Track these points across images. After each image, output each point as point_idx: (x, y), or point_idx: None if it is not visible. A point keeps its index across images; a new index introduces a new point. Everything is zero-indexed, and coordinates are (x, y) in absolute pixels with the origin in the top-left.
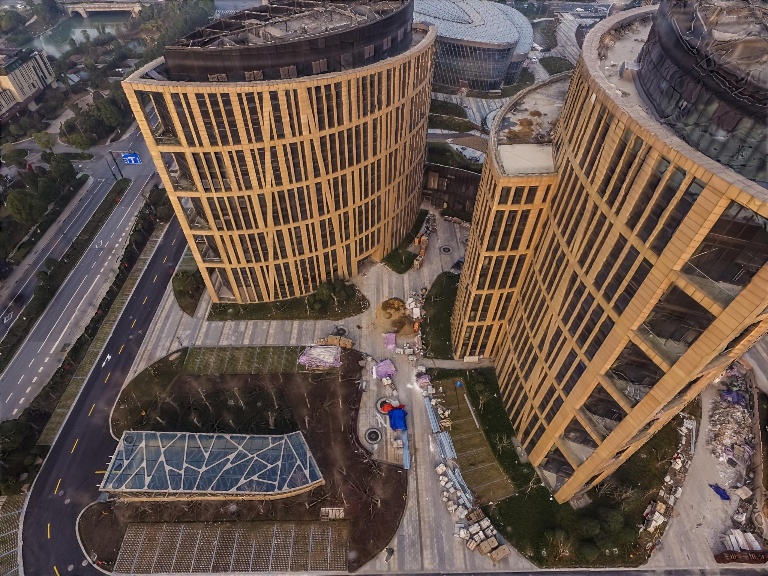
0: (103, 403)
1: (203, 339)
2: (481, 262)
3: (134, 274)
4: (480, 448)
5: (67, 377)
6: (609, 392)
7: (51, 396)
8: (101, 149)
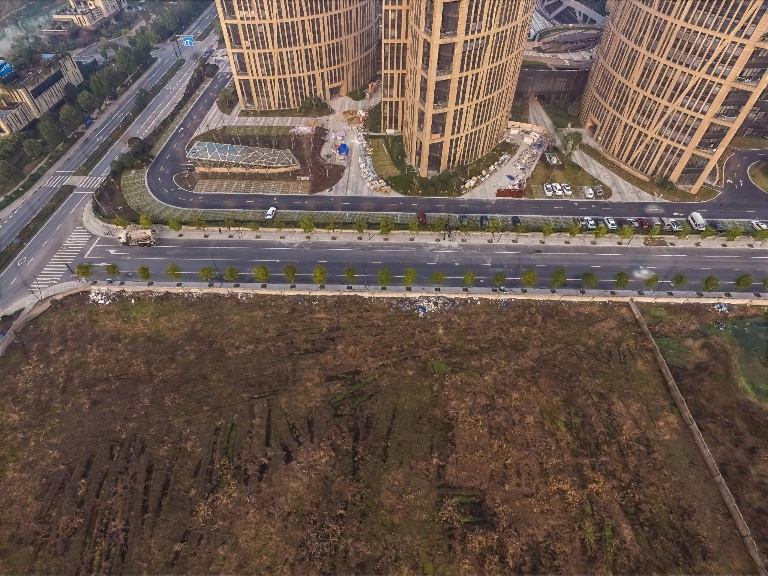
0: (181, 143)
1: (236, 123)
2: (383, 47)
3: (193, 99)
4: (386, 161)
5: (160, 134)
6: (422, 75)
7: (152, 140)
8: (164, 45)
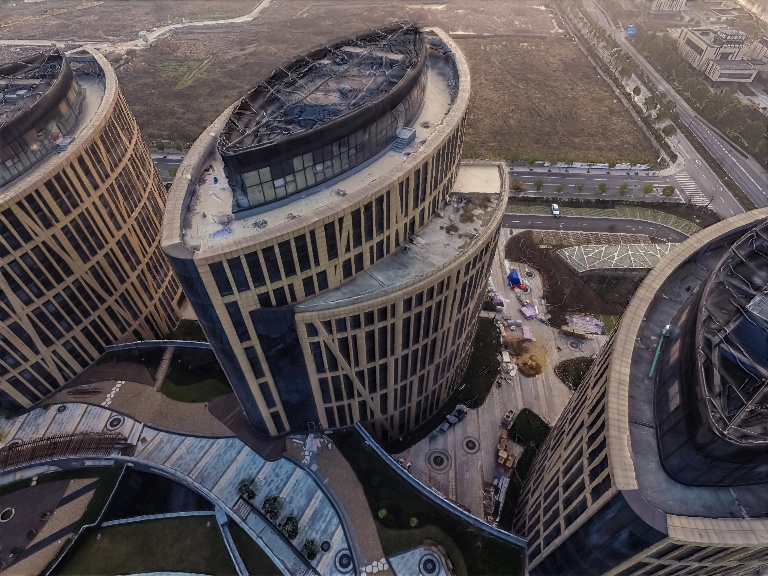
0: None
1: None
2: None
3: None
4: None
5: None
6: None
7: None
8: None
